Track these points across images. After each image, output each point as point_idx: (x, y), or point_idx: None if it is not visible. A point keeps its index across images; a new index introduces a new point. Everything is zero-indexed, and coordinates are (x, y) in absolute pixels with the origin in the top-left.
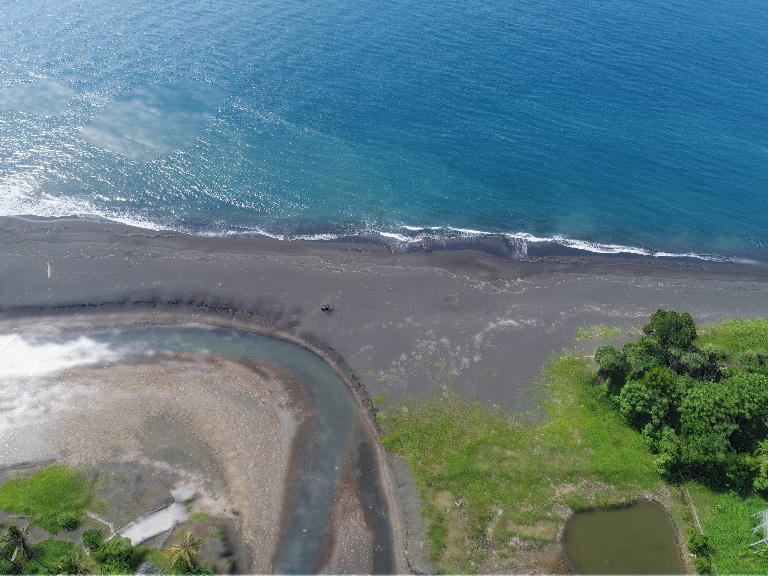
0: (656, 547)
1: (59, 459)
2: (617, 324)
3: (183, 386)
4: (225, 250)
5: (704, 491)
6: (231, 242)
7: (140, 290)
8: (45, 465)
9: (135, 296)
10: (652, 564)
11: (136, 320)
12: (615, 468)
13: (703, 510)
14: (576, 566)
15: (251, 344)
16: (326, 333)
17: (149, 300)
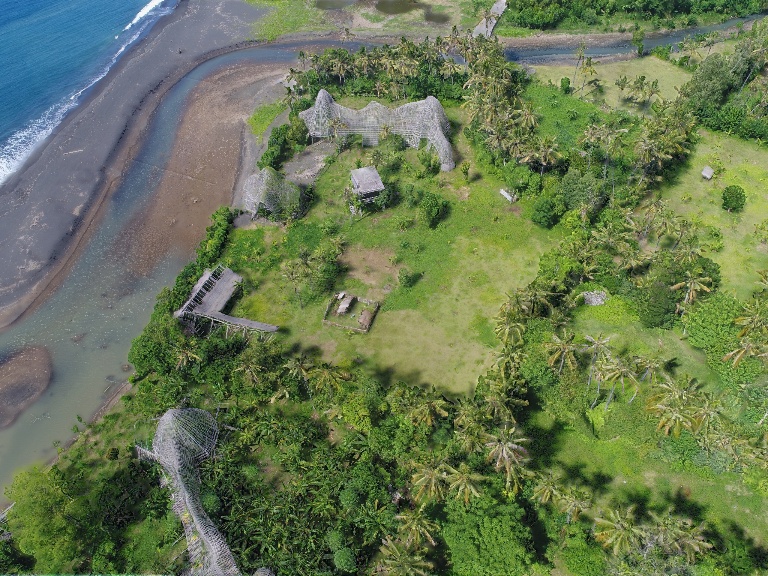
0: None
1: (243, 122)
2: None
3: (211, 94)
4: (101, 90)
5: None
6: (92, 91)
7: (123, 112)
8: (245, 125)
9: (127, 114)
10: None
11: (147, 116)
12: None
13: None
14: (335, 9)
15: (190, 78)
16: (198, 52)
17: (134, 109)
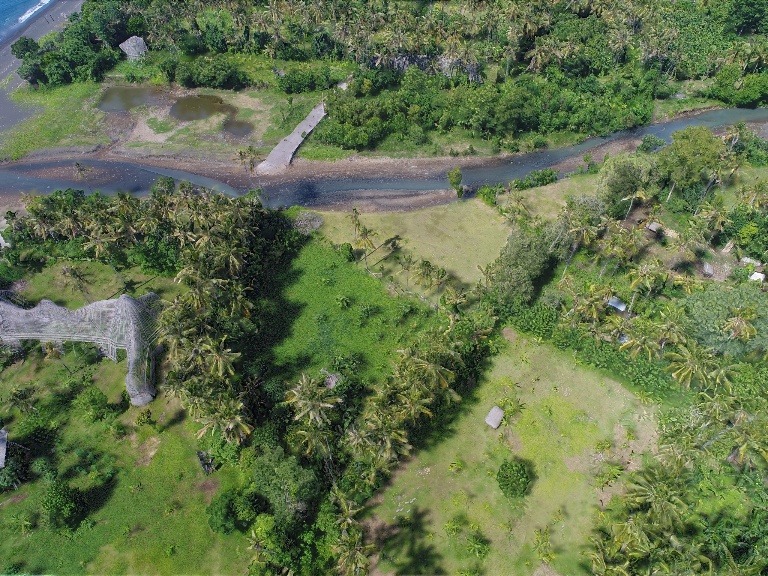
0: (126, 92)
1: None
2: (6, 75)
3: None
4: None
5: (111, 72)
6: None
7: None
8: None
9: None
10: (132, 94)
11: None
12: (85, 92)
13: (118, 74)
14: (121, 111)
15: None
16: None
17: None
